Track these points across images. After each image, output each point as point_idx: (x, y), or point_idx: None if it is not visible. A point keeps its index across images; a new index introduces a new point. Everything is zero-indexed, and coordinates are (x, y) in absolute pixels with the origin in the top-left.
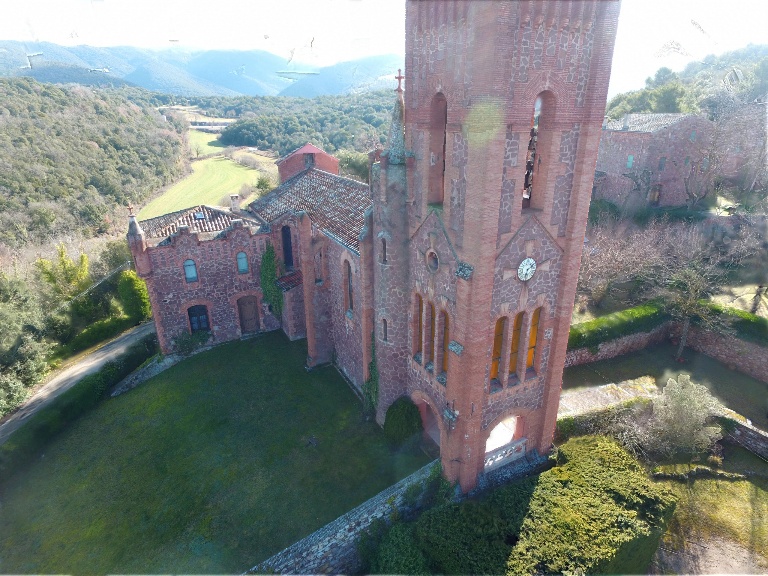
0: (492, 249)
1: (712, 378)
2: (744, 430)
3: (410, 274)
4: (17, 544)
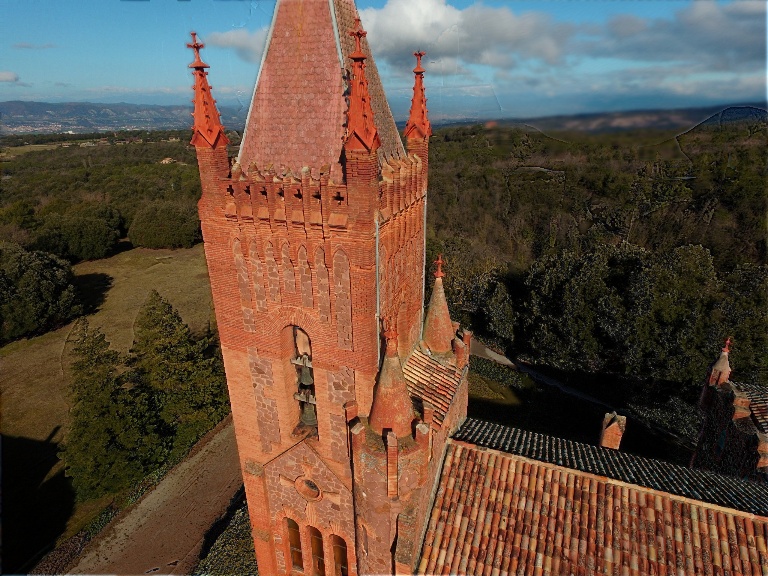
0: None
1: None
2: None
3: None
4: (521, 417)
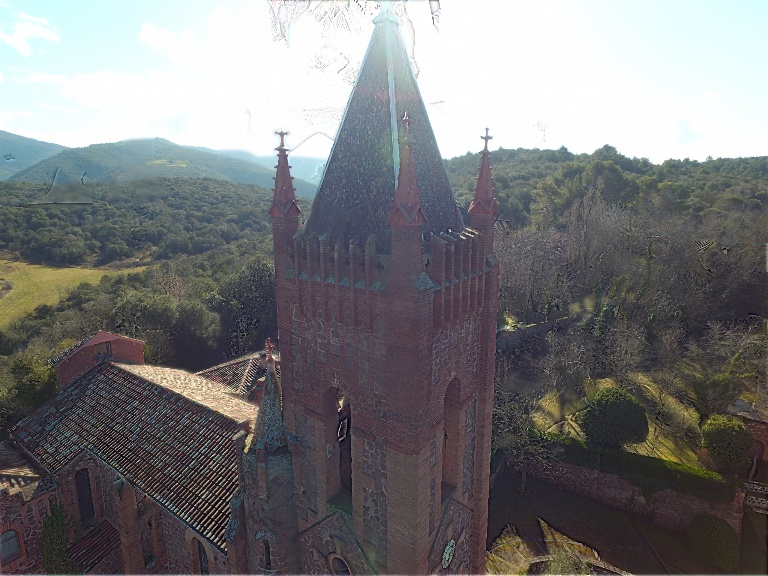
0: (425, 568)
1: (553, 507)
2: (599, 570)
3: (303, 572)
4: None
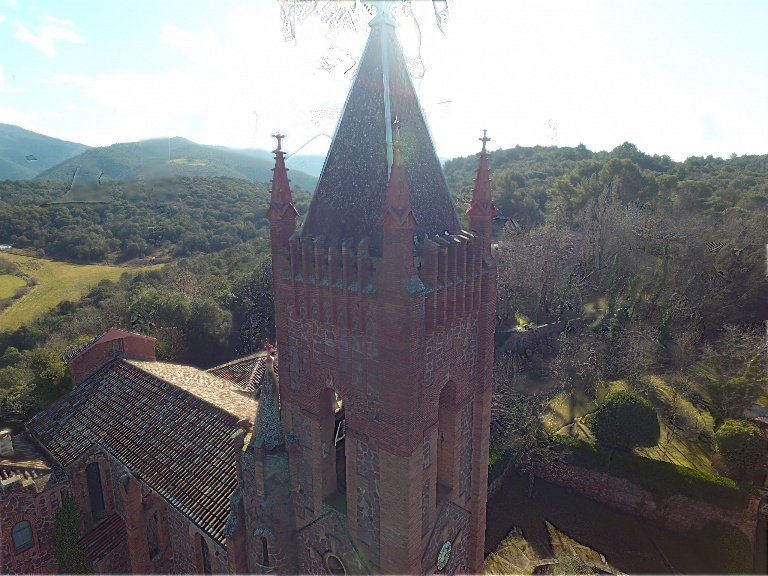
0: (418, 570)
1: (561, 510)
2: (606, 575)
3: (301, 569)
4: None
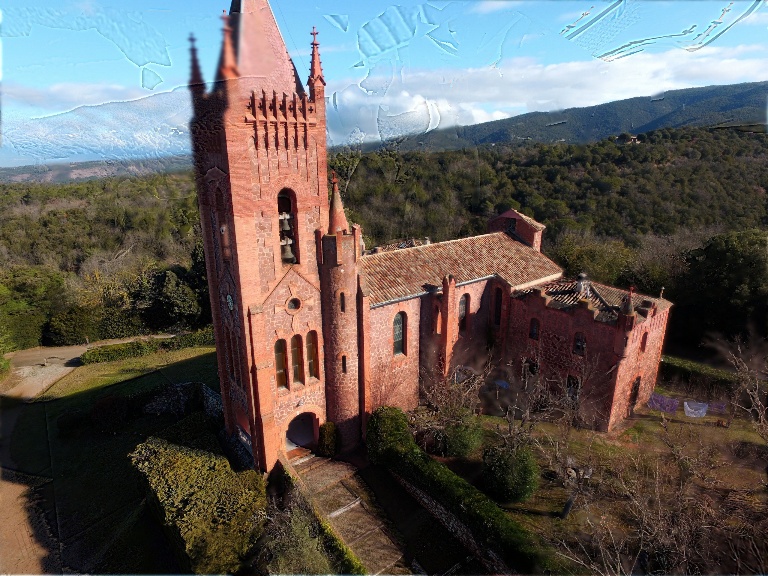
0: None
1: None
2: None
3: None
4: None
